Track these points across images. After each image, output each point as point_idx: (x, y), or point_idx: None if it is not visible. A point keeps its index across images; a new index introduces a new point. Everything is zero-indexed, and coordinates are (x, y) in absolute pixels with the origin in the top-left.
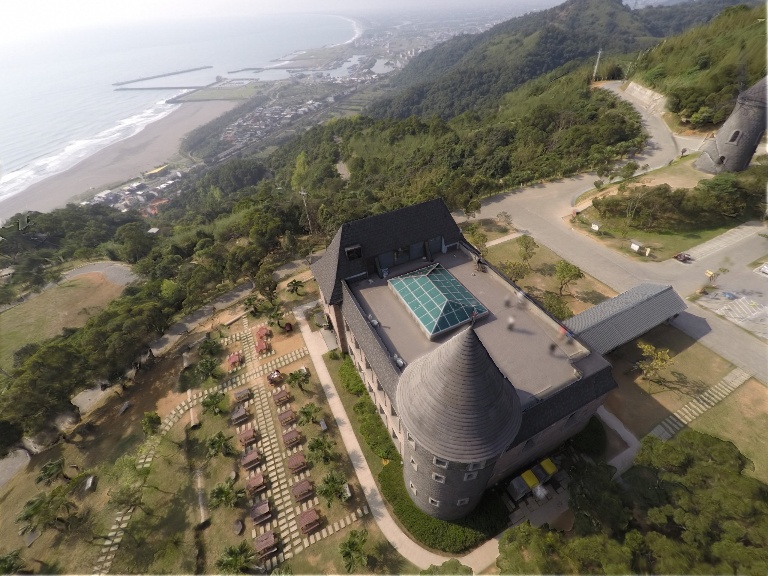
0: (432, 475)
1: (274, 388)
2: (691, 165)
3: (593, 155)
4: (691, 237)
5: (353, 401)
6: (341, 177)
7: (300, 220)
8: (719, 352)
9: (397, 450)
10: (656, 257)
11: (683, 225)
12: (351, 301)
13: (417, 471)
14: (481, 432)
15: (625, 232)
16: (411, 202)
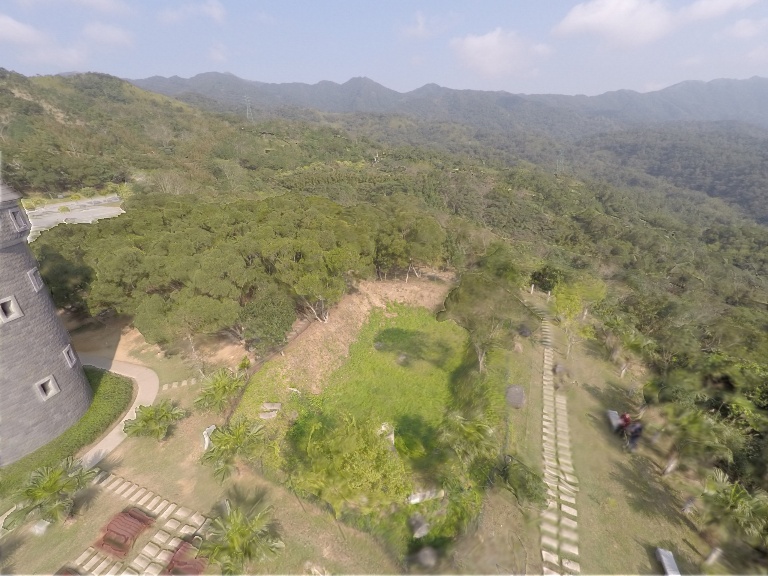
0: (32, 284)
1: None
2: None
3: None
4: None
5: None
6: None
7: None
8: None
9: None
10: None
11: None
12: None
13: (23, 313)
14: None
15: None
16: None
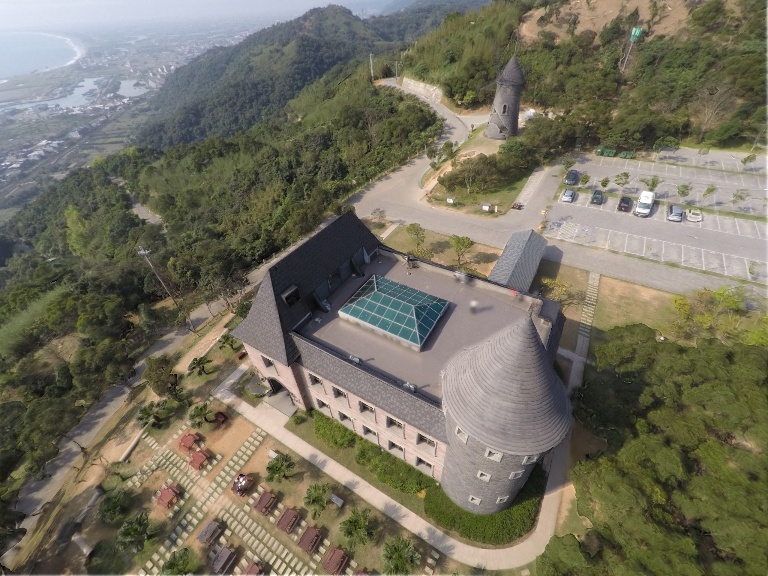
0: (510, 476)
1: (248, 498)
2: (484, 136)
3: (415, 142)
4: (512, 189)
5: (351, 455)
6: (151, 222)
7: (145, 286)
8: (576, 266)
9: (426, 475)
10: (501, 211)
11: (502, 182)
12: (315, 350)
13: (489, 482)
14: (558, 409)
15: (475, 198)
16: (270, 225)
